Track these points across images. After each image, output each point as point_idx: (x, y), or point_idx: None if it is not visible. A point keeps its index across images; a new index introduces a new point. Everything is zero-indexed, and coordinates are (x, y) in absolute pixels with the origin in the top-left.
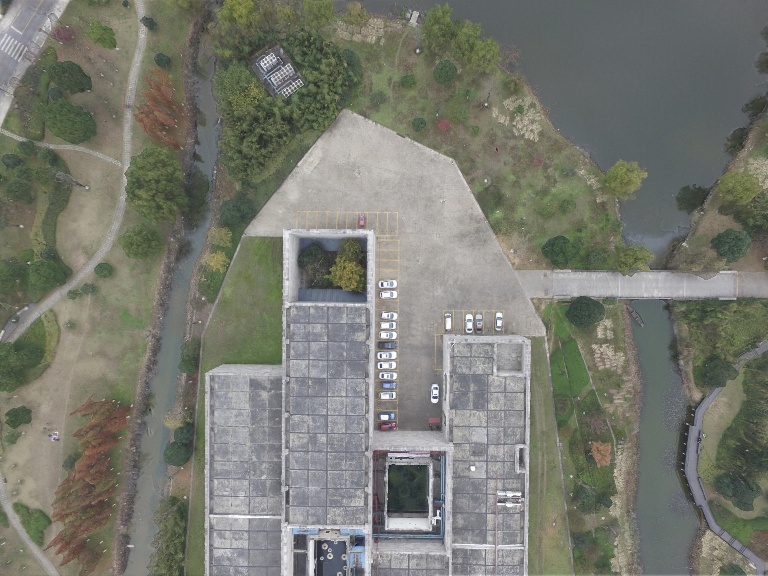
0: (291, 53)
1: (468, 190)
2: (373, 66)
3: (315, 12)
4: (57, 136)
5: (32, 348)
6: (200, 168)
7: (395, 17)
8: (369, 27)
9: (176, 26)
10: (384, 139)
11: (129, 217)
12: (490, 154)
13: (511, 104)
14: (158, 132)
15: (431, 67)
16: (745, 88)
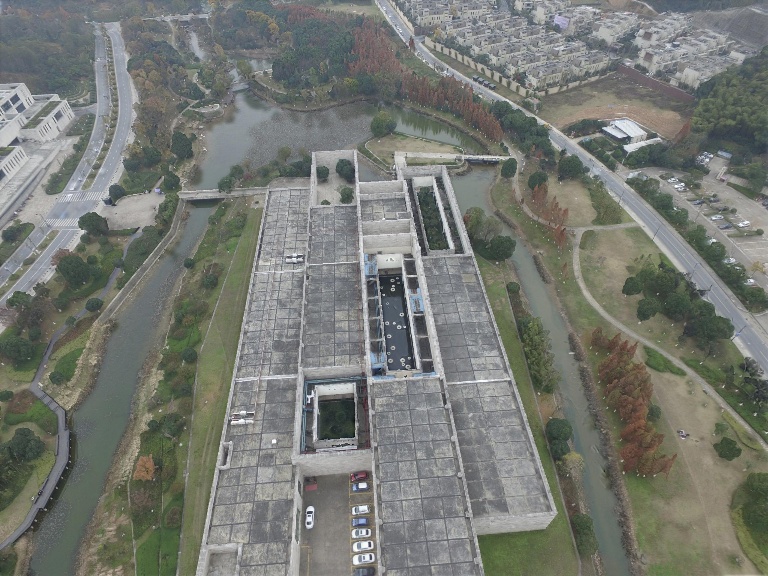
0: None
1: None
2: None
3: None
4: None
5: (760, 526)
6: None
7: None
8: None
9: None
10: None
11: None
12: None
13: None
14: None
15: None
16: None
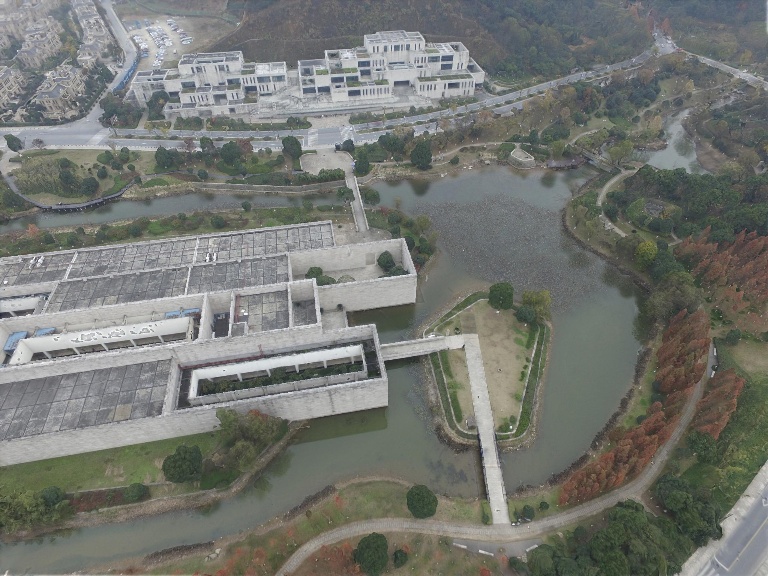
0: None
1: None
2: None
3: None
4: None
5: None
6: None
7: None
8: None
9: None
10: None
11: None
12: None
13: None
14: None
15: None
16: None
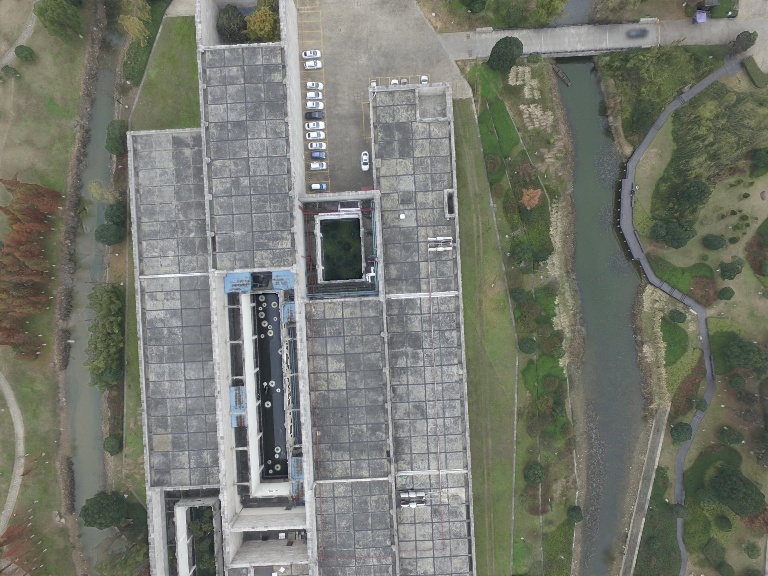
0: None
1: None
2: None
3: None
4: None
5: None
6: None
7: None
8: None
9: None
10: None
11: None
12: None
13: None
14: None
15: None
16: None
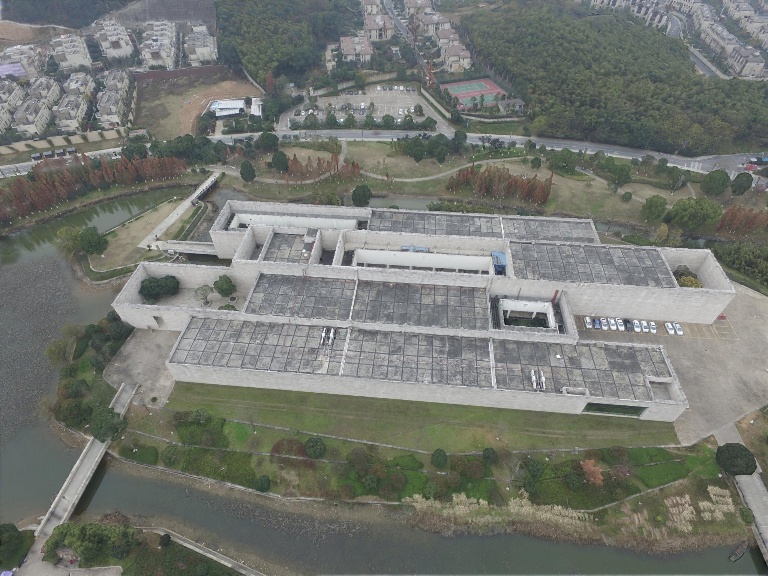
0: None
1: None
2: None
3: None
4: None
5: None
6: None
7: None
8: None
9: None
10: None
11: None
12: None
13: None
14: None
15: None
16: None
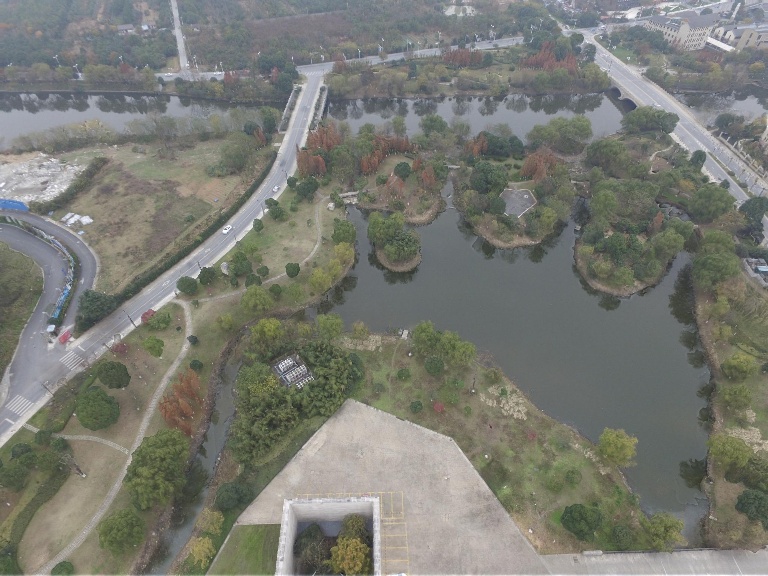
0: (306, 356)
1: (471, 466)
2: (373, 366)
3: (328, 327)
4: (81, 421)
5: None
6: (202, 462)
7: (390, 334)
8: (369, 340)
9: (214, 343)
10: (385, 422)
11: (116, 507)
12: (485, 432)
13: (495, 390)
14: (176, 417)
15: (422, 365)
16: (690, 380)
